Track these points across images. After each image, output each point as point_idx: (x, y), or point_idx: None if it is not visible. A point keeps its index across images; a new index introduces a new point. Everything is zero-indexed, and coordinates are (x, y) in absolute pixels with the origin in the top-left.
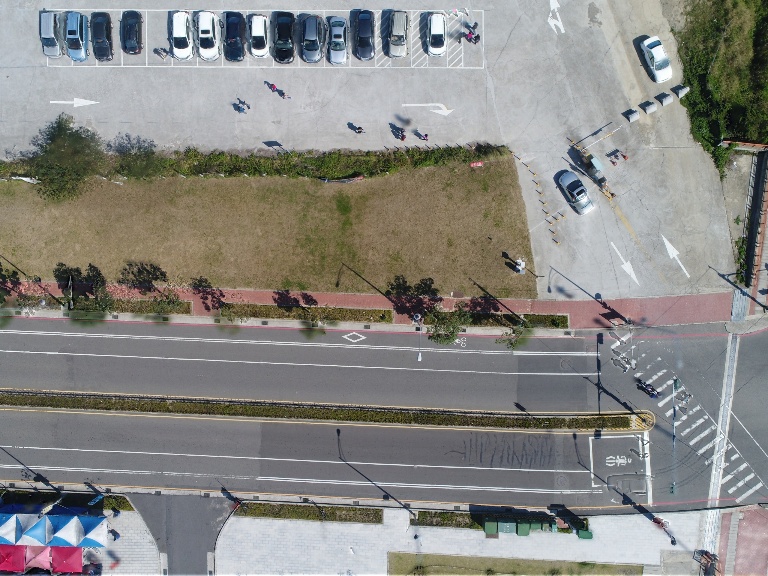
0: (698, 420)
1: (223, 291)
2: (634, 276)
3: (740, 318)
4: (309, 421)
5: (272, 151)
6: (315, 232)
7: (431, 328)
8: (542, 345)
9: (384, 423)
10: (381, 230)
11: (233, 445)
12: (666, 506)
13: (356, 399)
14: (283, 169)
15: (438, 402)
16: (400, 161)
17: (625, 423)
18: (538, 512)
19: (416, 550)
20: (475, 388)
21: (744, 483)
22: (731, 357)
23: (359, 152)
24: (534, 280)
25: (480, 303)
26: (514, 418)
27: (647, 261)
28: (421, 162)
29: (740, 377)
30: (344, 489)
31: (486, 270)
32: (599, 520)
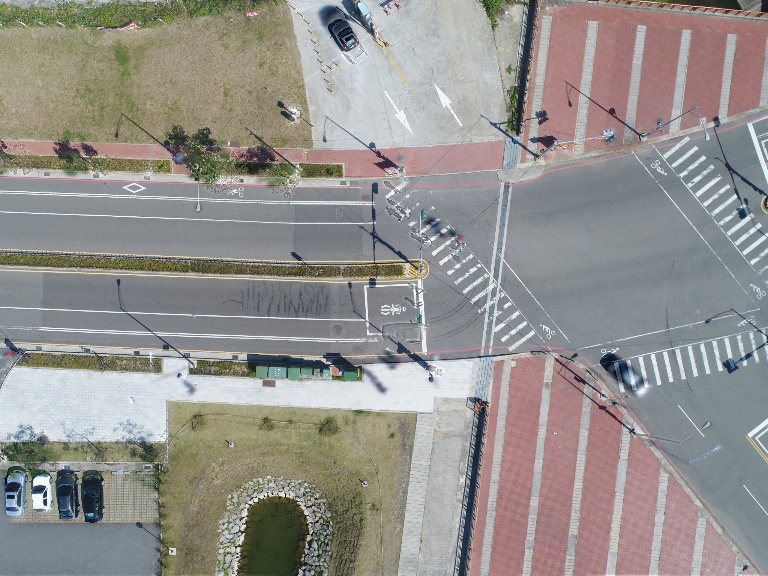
0: (471, 268)
1: (5, 142)
2: (408, 125)
3: (511, 166)
4: (90, 271)
5: (53, 2)
6: (94, 82)
7: (209, 178)
8: (318, 195)
9: (162, 272)
10: (159, 80)
11: (16, 296)
12: (440, 354)
13: (136, 249)
14: (60, 18)
15: (216, 252)
16: (176, 10)
17: (398, 271)
18: (314, 361)
19: (194, 399)
20: (252, 238)
21: (517, 331)
22: (503, 206)
23: (137, 2)
24: (309, 129)
25: (257, 153)
26: (290, 267)
27: (420, 110)
28: (196, 11)
29: (512, 225)
30: (125, 339)
31: (262, 120)
32: (374, 368)
